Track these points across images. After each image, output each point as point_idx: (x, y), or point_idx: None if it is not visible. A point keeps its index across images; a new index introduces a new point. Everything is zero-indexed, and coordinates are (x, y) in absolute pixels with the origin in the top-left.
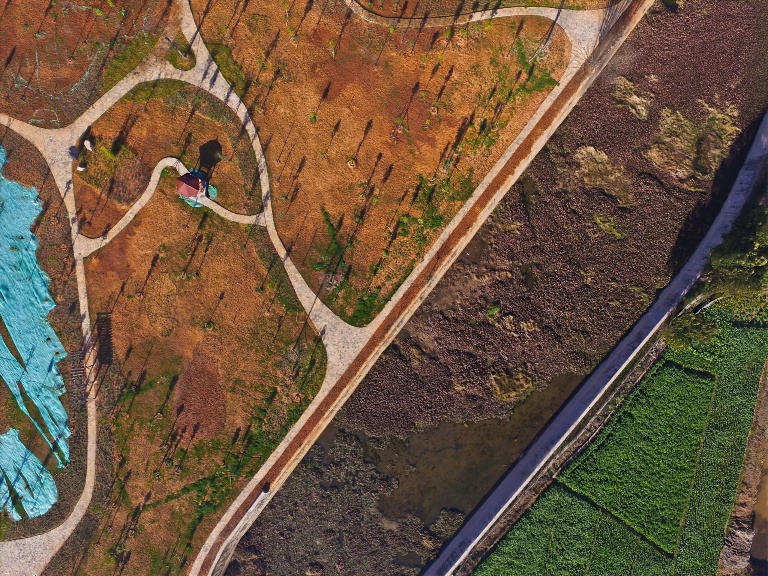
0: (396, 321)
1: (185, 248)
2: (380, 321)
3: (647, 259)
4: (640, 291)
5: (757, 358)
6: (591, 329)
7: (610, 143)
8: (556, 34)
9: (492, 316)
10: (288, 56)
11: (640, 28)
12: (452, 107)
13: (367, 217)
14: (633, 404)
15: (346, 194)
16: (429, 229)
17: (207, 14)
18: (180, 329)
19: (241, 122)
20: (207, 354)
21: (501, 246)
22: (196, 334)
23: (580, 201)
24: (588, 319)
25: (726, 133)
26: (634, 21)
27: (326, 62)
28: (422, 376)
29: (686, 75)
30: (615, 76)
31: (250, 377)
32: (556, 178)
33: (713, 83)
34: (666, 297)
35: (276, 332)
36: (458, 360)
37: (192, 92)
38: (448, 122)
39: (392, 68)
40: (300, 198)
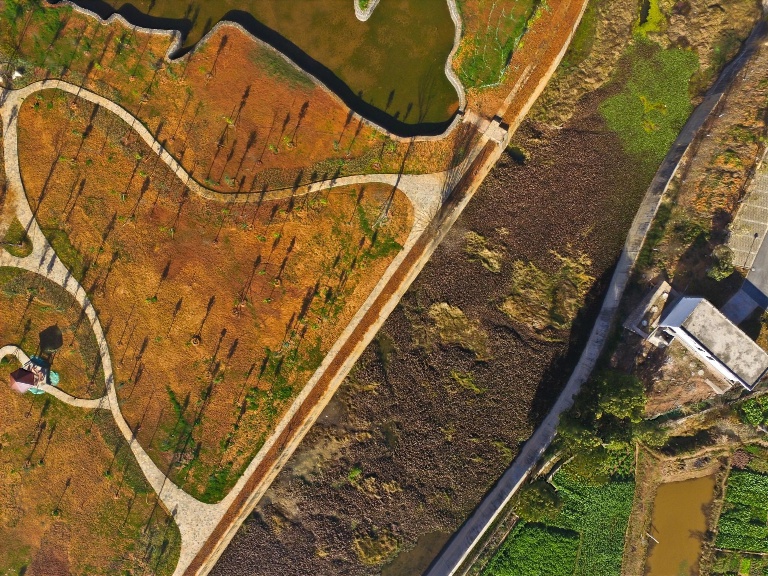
0: (250, 495)
1: (28, 436)
2: (233, 496)
3: (508, 413)
4: (502, 446)
5: (621, 513)
6: (455, 487)
7: (464, 298)
8: (398, 199)
9: (354, 478)
10: (126, 237)
11: (487, 182)
12: (296, 278)
13: (214, 393)
14: (497, 567)
15: (191, 372)
16: (279, 400)
17: (42, 199)
18: (26, 519)
19: (81, 306)
20: (55, 542)
21: (359, 407)
22: (43, 523)
23: (437, 358)
24: (451, 477)
25: (581, 282)
26: (477, 180)
27: (165, 241)
28: (285, 543)
29: (537, 226)
30: (465, 231)
31: (101, 562)
32: (412, 335)
33: (564, 233)
34: (528, 452)
35: (126, 515)
36: (321, 525)
37: (30, 279)
38: (292, 293)
39: (232, 243)
40: (144, 379)
